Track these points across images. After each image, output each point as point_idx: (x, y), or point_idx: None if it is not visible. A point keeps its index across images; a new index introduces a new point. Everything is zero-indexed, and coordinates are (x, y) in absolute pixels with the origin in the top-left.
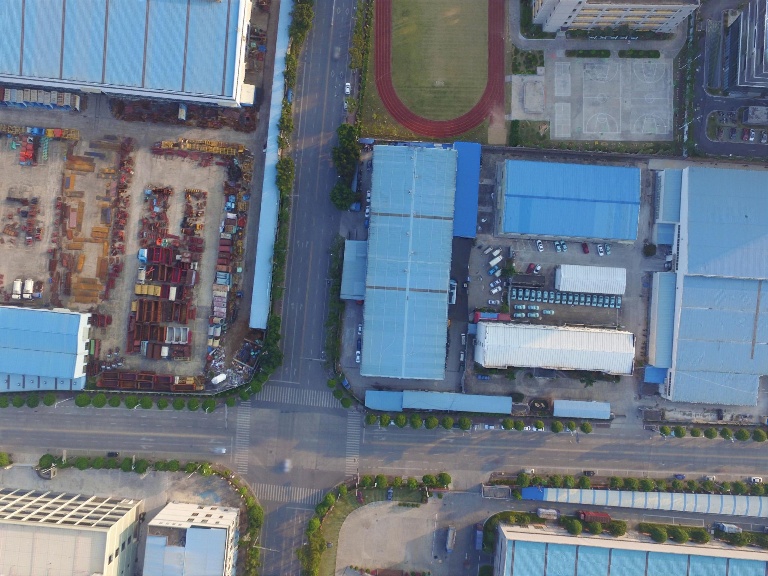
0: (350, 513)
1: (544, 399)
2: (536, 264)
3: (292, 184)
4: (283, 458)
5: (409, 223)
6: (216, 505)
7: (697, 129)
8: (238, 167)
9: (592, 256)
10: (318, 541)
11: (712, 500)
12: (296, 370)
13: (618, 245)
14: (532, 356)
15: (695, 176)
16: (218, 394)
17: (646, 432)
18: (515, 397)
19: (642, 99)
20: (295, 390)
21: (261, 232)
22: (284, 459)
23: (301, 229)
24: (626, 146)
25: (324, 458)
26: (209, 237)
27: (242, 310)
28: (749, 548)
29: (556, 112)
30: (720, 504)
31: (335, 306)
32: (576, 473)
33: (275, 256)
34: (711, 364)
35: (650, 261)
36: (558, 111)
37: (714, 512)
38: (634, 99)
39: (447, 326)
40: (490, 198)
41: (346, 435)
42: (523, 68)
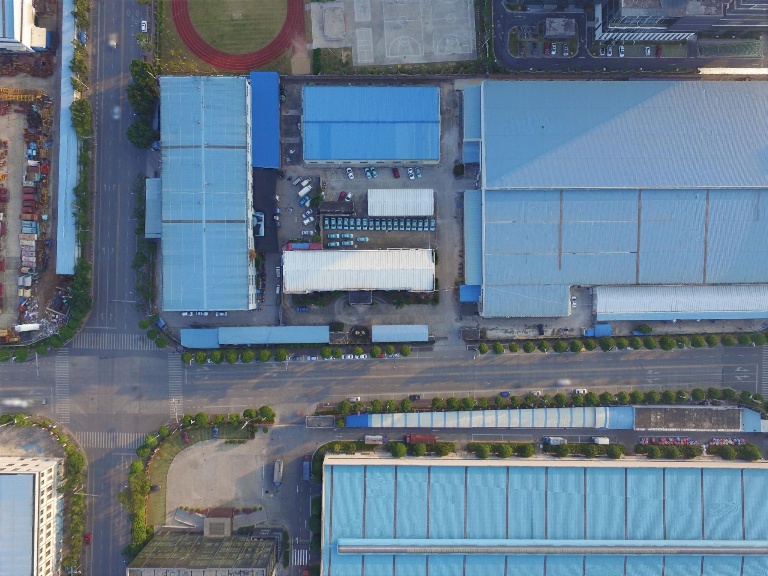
0: (177, 454)
1: (365, 327)
2: (347, 192)
3: (94, 127)
4: (105, 405)
5: (201, 154)
6: (39, 456)
7: (499, 46)
8: (37, 113)
9: (404, 180)
10: (139, 482)
11: (536, 414)
12: (112, 315)
13: (429, 168)
14: (332, 279)
15: (490, 90)
16: (32, 344)
17: (469, 352)
18: (334, 326)
19: (443, 20)
20: (112, 335)
21: (62, 177)
22: (106, 405)
23: (107, 172)
24: (430, 68)
25: (147, 401)
26: (13, 187)
27: (52, 258)
28: (573, 458)
29: (358, 38)
30: (544, 417)
31: (143, 247)
32: (402, 398)
33: (78, 200)
34: (520, 277)
35: (462, 182)
36: (360, 37)
37: (539, 426)
38: (435, 20)
39: (251, 257)
40: (297, 129)
41: (168, 377)
42: None
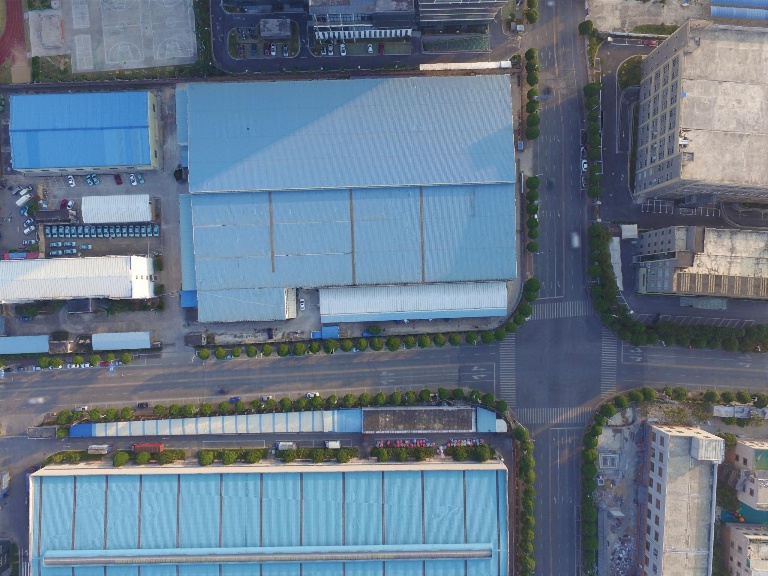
0: None
1: (90, 335)
2: (69, 200)
3: None
4: None
5: None
6: None
7: (219, 49)
8: None
9: (127, 187)
10: None
11: (263, 419)
12: None
13: (152, 173)
14: (28, 288)
15: (195, 93)
16: None
17: (198, 358)
18: (55, 335)
19: (163, 24)
20: None
21: None
22: None
23: None
24: (150, 73)
25: None
26: None
27: None
28: (299, 463)
29: (76, 45)
30: (272, 422)
31: None
32: (131, 406)
33: None
34: (233, 281)
35: (186, 186)
36: (78, 44)
37: (268, 431)
38: (155, 24)
39: None
40: None
41: None
42: (39, 3)
